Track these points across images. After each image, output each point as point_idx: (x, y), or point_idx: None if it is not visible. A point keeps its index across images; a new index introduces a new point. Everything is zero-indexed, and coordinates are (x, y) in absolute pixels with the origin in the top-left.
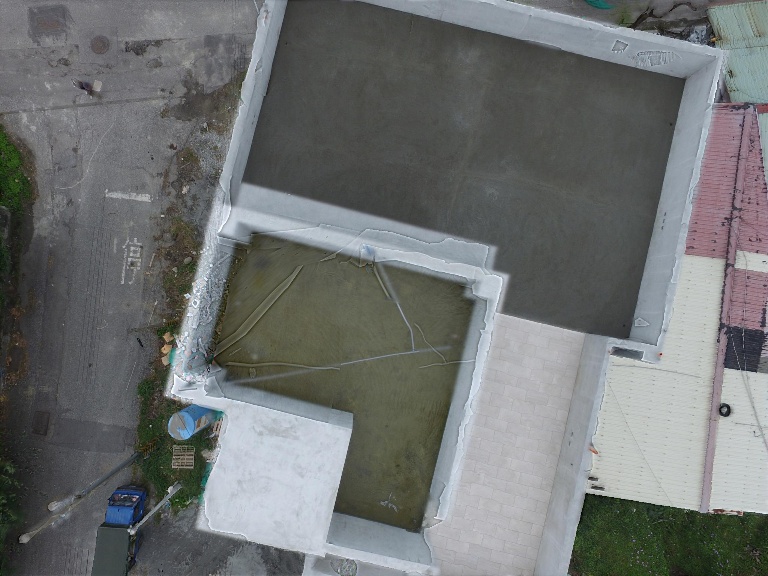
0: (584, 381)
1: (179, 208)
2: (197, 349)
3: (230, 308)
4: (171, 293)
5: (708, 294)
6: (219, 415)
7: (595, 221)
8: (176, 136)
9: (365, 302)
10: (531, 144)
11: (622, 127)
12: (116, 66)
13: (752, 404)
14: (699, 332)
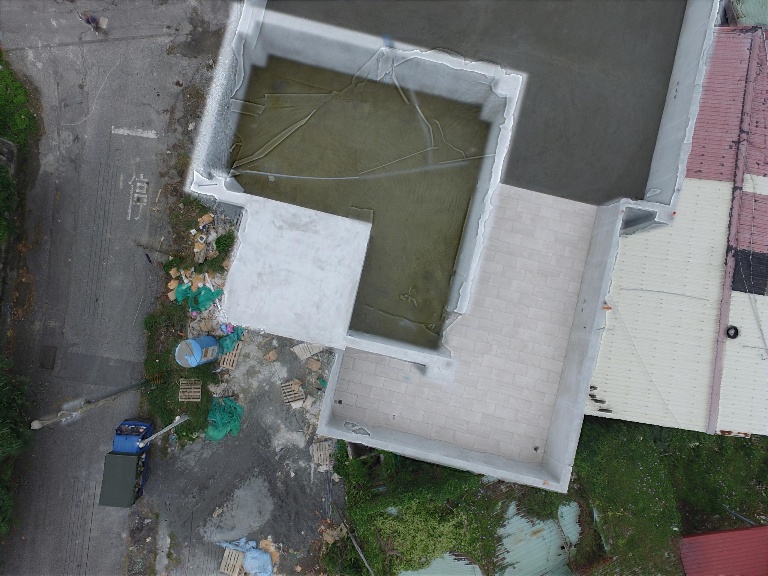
0: (597, 248)
1: (185, 145)
2: (204, 284)
3: (246, 142)
4: (177, 229)
5: (715, 217)
6: (239, 210)
7: (607, 94)
8: (182, 73)
9: (383, 116)
10: (543, 18)
11: (634, 1)
12: (122, 3)
13: (759, 327)
14: (706, 255)
